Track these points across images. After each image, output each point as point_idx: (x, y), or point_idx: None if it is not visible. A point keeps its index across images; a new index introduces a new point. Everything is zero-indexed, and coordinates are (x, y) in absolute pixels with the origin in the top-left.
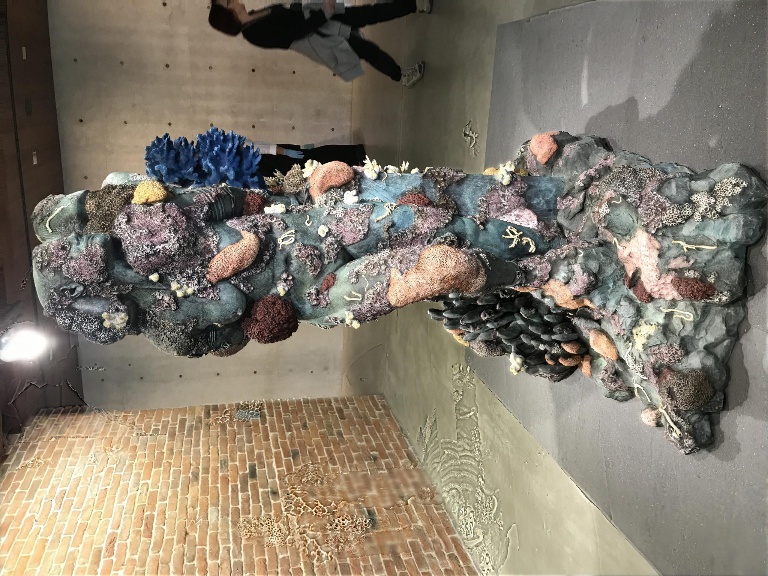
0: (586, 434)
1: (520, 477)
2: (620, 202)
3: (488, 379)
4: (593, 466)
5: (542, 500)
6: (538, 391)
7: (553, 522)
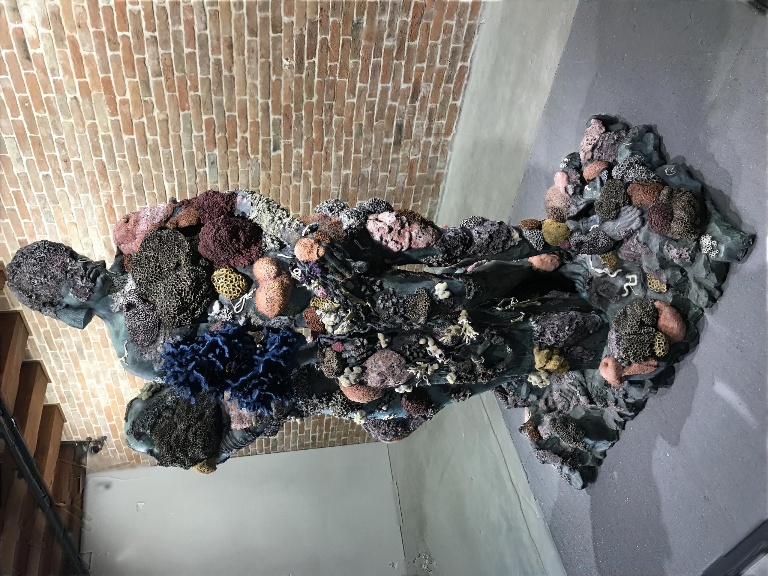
0: (535, 217)
1: (557, 5)
2: (532, 446)
3: (584, 4)
4: (524, 217)
5: (544, 56)
6: (561, 143)
7: (535, 74)
